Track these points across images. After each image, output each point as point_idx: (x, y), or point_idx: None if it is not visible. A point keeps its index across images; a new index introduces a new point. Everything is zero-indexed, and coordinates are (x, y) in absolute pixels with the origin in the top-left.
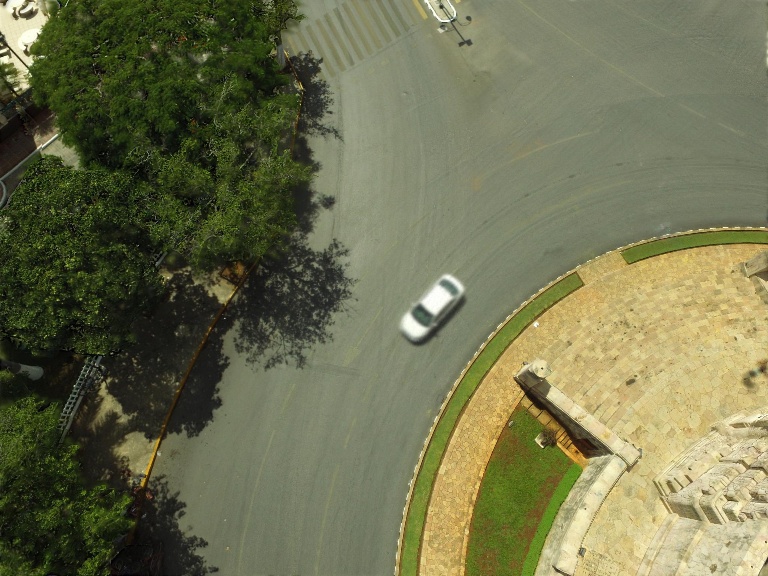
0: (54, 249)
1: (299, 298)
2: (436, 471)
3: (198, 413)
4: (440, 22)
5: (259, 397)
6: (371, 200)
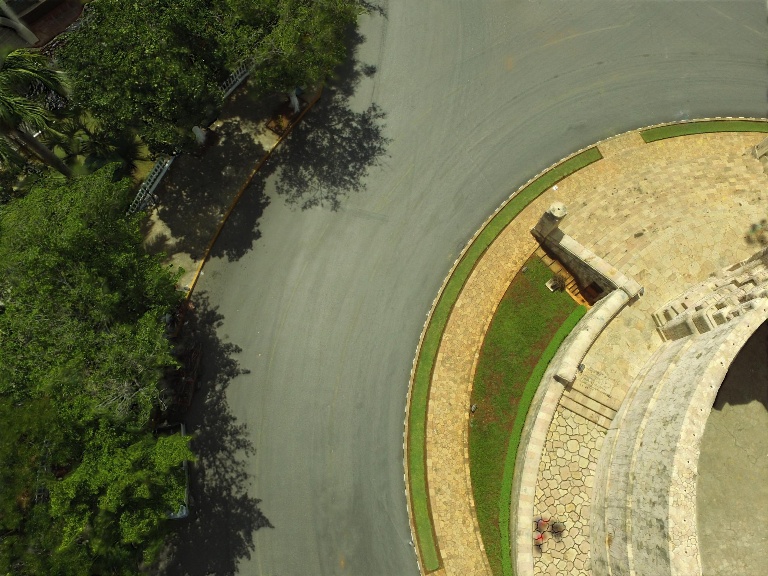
0: (136, 37)
1: (337, 151)
2: (453, 305)
3: (239, 242)
4: None
5: (295, 232)
6: (410, 72)
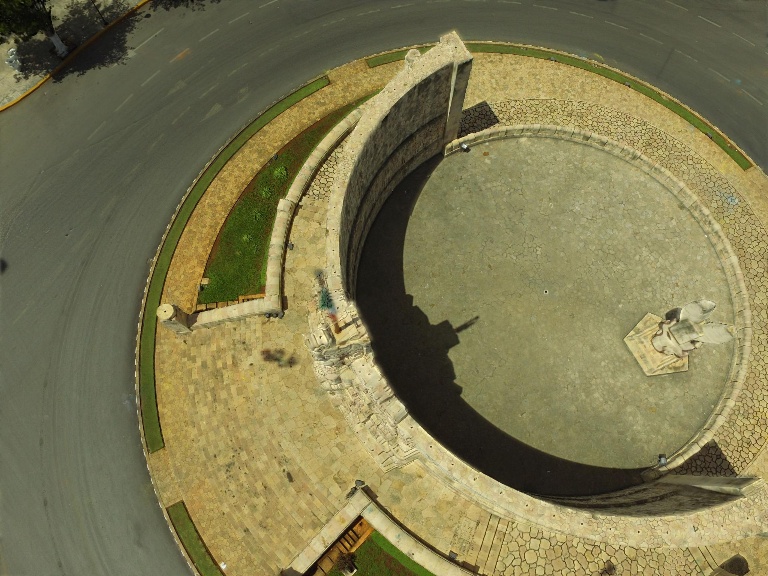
0: None
1: None
2: None
3: None
4: None
5: None
6: None
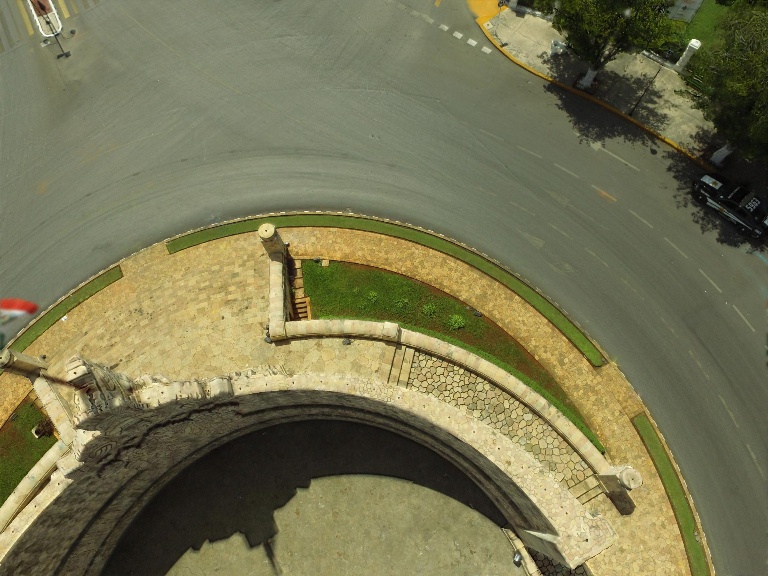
0: None
1: None
2: None
3: None
4: (44, 37)
5: None
6: None
